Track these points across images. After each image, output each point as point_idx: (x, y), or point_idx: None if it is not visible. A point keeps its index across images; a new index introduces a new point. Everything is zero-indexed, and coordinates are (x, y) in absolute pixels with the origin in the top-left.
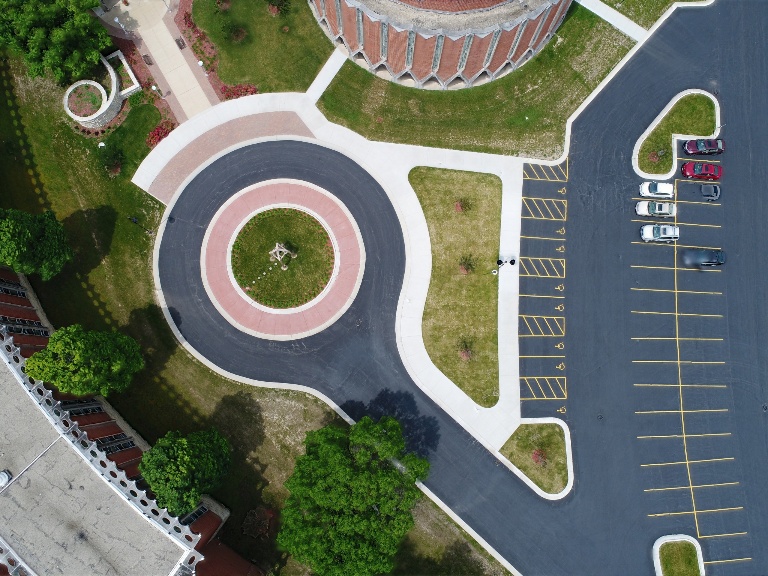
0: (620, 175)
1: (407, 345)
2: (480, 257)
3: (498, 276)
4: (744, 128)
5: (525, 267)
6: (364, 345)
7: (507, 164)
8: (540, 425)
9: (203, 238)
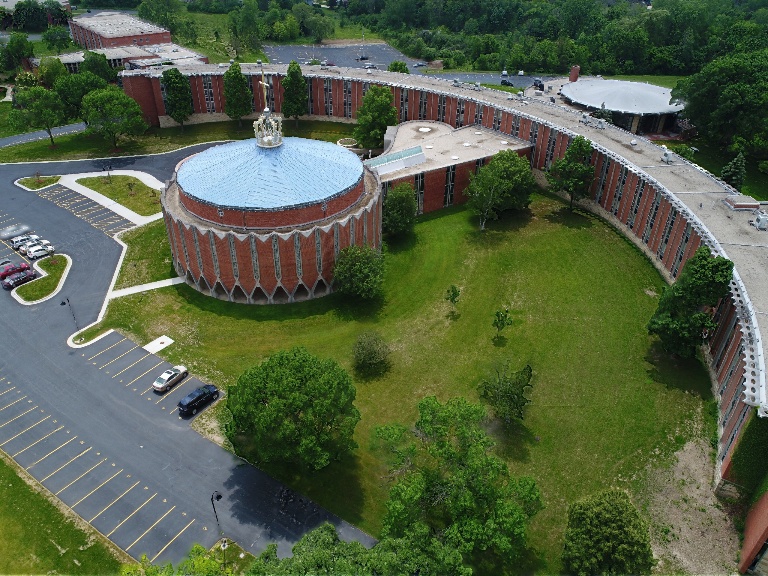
0: (72, 248)
1: None
2: None
3: None
4: None
5: None
6: None
7: (147, 220)
8: None
9: None
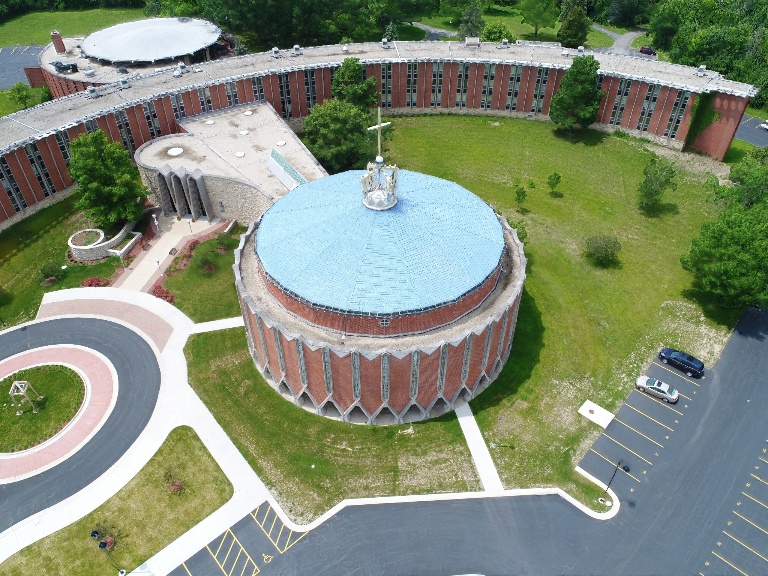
0: None
1: None
2: (131, 545)
3: None
4: None
5: None
6: None
7: (253, 488)
8: None
9: (19, 353)
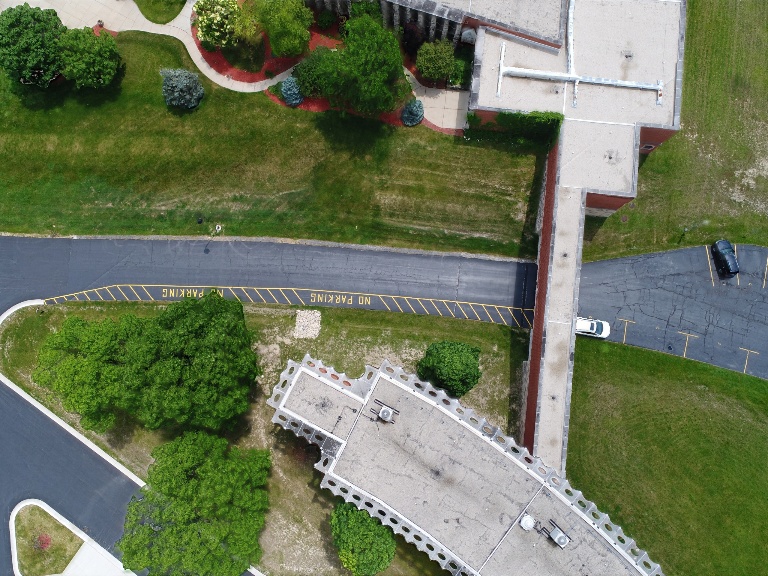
0: None
1: None
2: None
3: None
4: None
5: None
6: None
7: None
8: (43, 574)
9: None
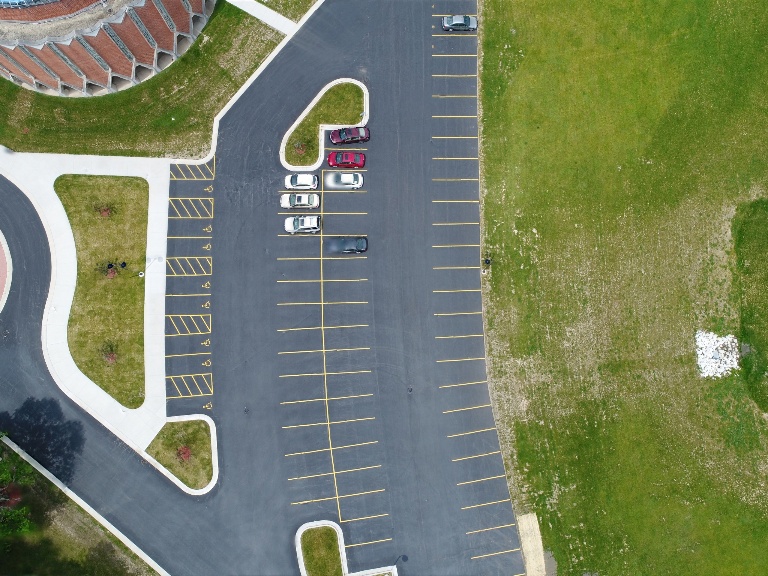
0: (267, 169)
1: (53, 352)
2: (126, 260)
3: (145, 278)
4: (392, 114)
5: (172, 267)
6: (10, 355)
7: (153, 166)
8: (186, 422)
9: None
